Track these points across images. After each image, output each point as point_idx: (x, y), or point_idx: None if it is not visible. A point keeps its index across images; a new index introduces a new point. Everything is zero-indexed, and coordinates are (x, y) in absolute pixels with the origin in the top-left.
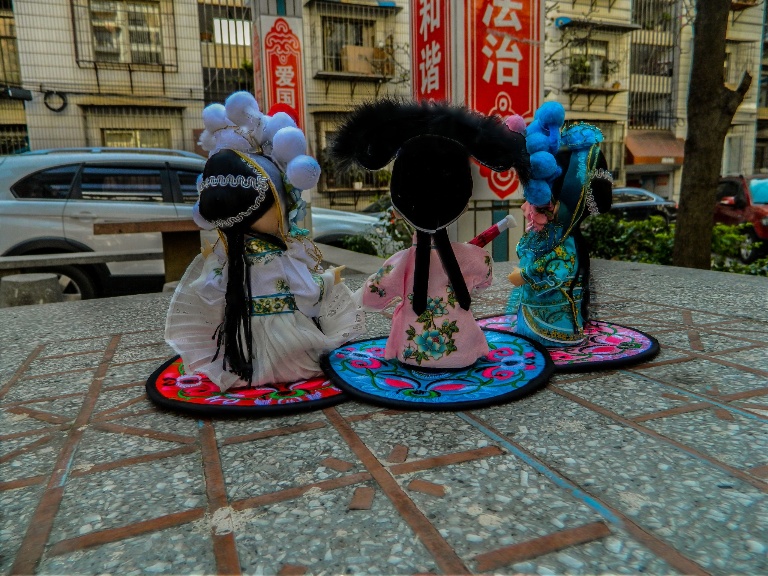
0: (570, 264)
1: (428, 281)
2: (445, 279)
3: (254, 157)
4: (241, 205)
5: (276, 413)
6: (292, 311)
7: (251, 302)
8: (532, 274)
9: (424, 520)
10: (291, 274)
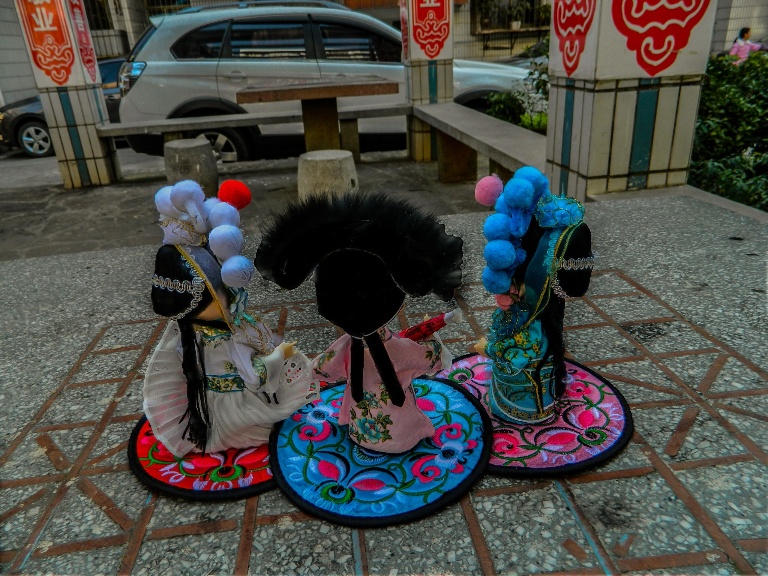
0: (532, 352)
1: (363, 376)
2: (378, 378)
3: (194, 253)
4: (178, 307)
5: (206, 500)
6: (241, 389)
7: (206, 379)
8: (493, 354)
9: None
10: (236, 359)
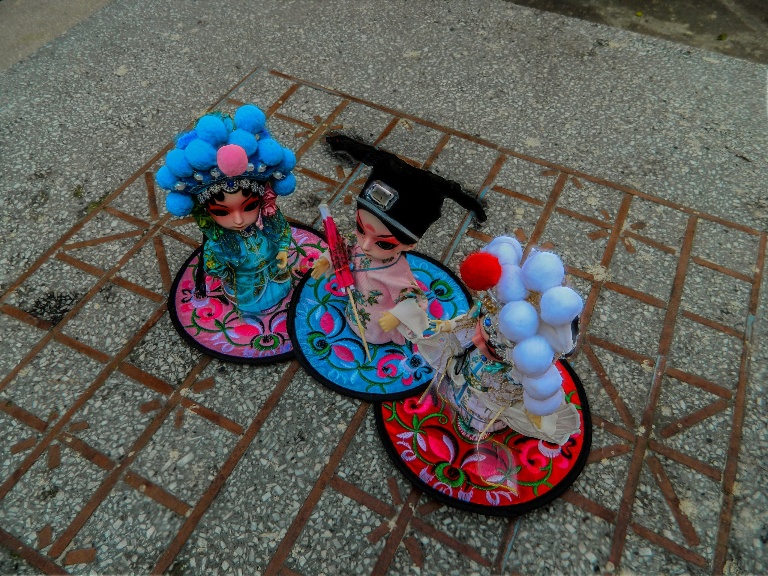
0: None
1: None
2: None
3: None
4: None
5: None
6: None
7: None
8: None
9: (538, 224)
10: None
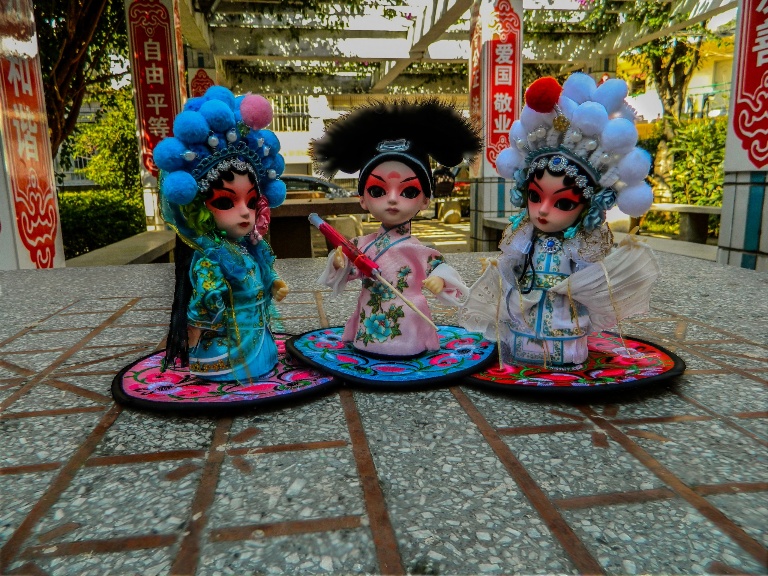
0: None
1: None
2: None
3: None
4: None
5: None
6: None
7: None
8: None
9: None
10: None
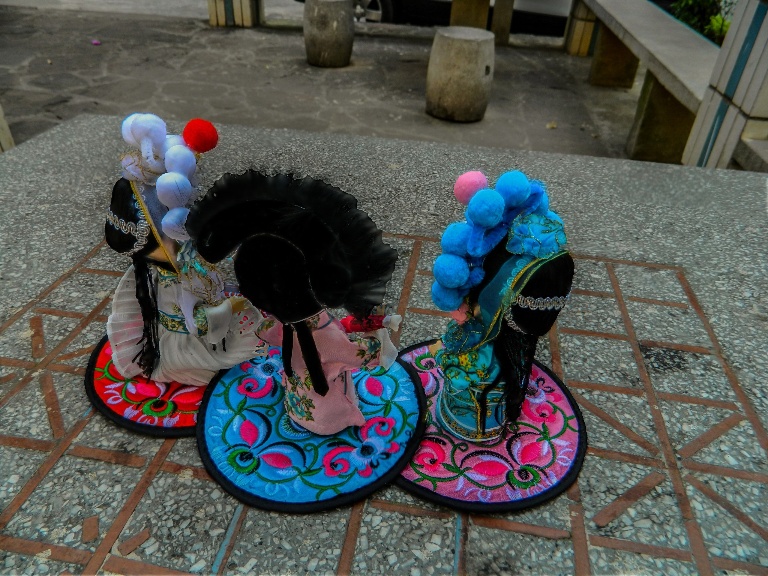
0: (476, 376)
1: (291, 356)
2: (303, 363)
3: (146, 194)
4: (124, 246)
5: (130, 430)
6: (187, 332)
7: (158, 313)
8: None
9: None
10: (182, 305)
